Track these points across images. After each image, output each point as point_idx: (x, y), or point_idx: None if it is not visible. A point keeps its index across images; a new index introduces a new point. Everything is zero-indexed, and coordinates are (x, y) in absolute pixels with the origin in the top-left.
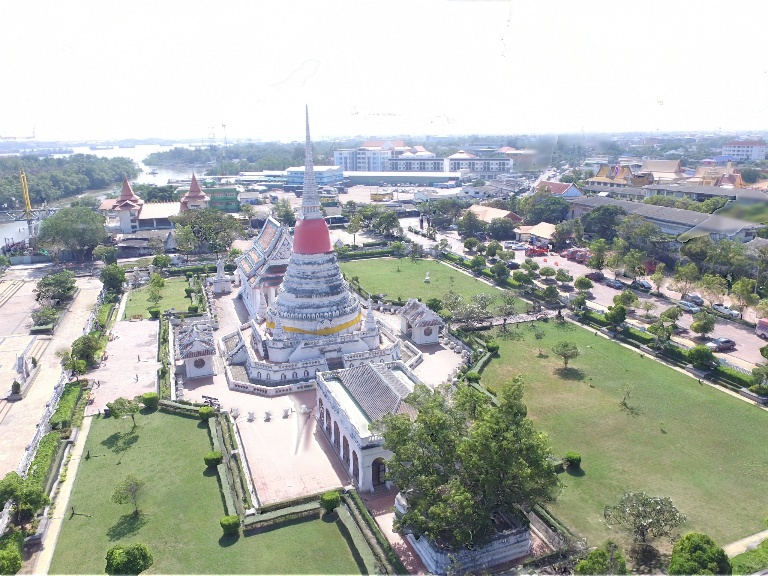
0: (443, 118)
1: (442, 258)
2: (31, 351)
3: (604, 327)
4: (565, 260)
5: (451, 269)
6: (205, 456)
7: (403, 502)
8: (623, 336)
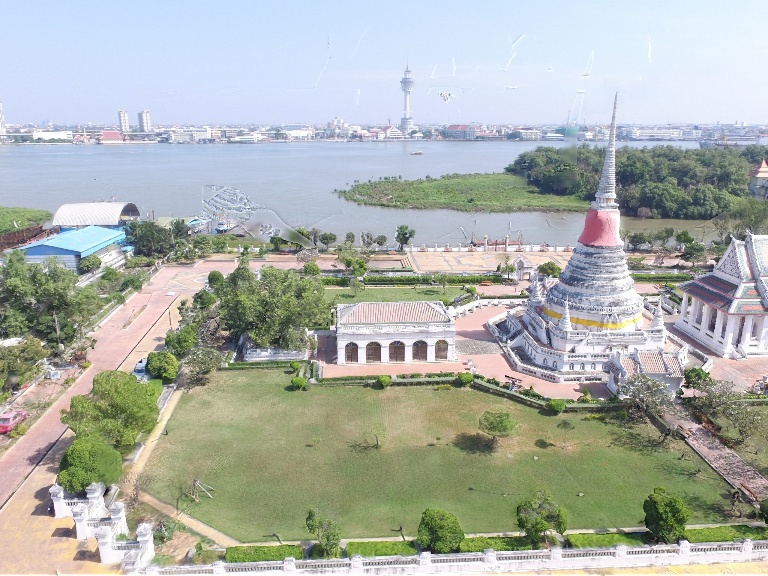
0: None
1: None
2: None
3: None
4: None
5: None
6: None
7: None
8: None
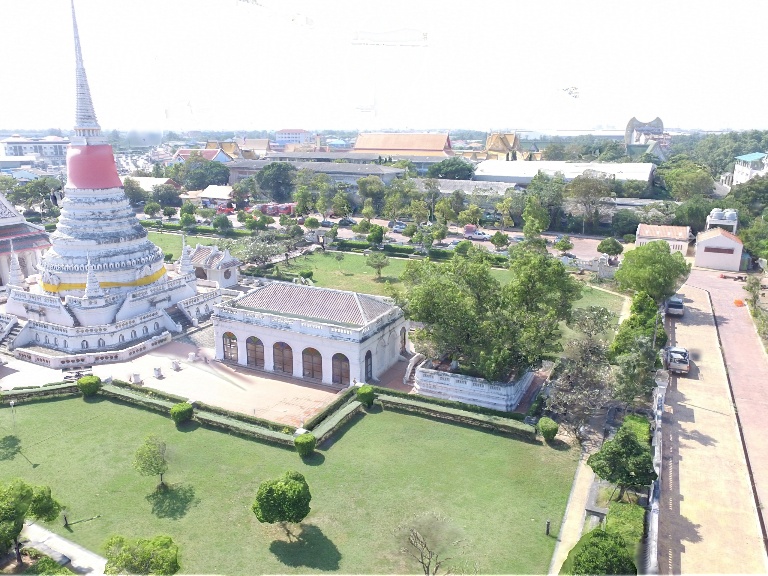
0: (303, 17)
1: None
2: None
3: (366, 249)
4: None
5: (154, 233)
6: (174, 410)
7: (433, 370)
8: (389, 252)
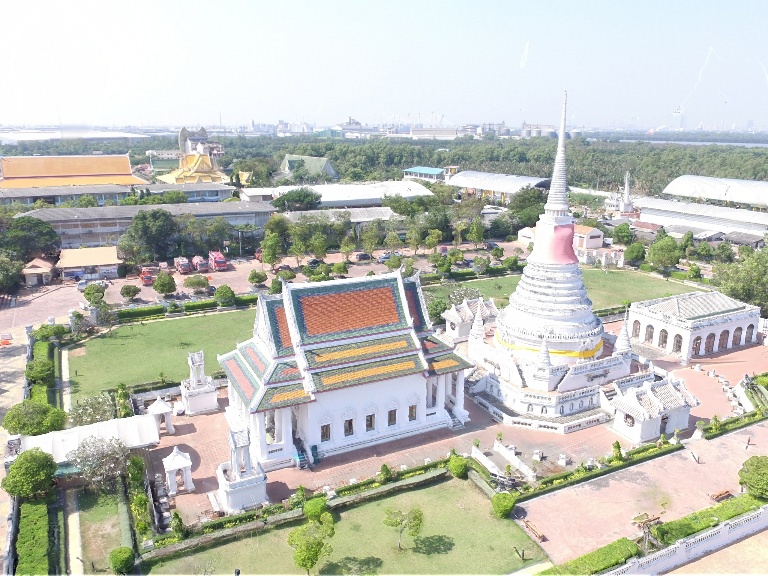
0: None
1: (126, 319)
2: None
3: (441, 279)
4: (186, 276)
5: (193, 318)
6: None
7: None
8: (460, 277)
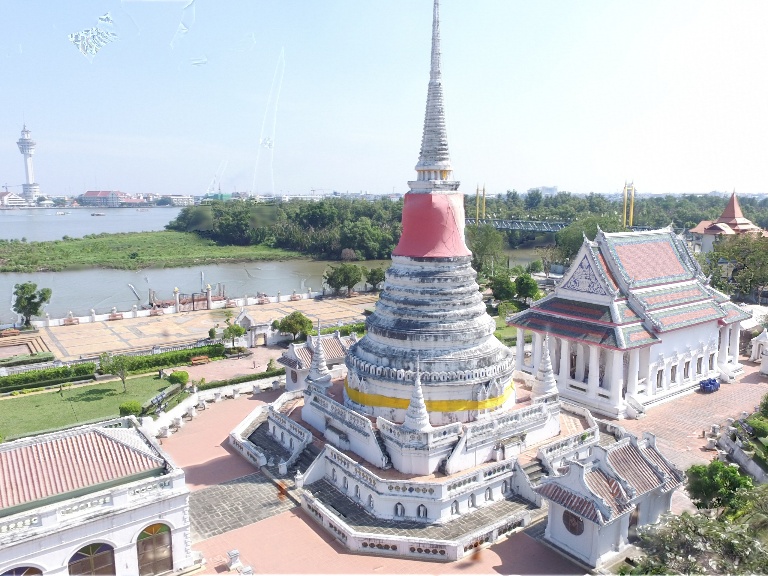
0: None
1: None
2: (321, 322)
3: None
4: None
5: None
6: None
7: None
8: None
